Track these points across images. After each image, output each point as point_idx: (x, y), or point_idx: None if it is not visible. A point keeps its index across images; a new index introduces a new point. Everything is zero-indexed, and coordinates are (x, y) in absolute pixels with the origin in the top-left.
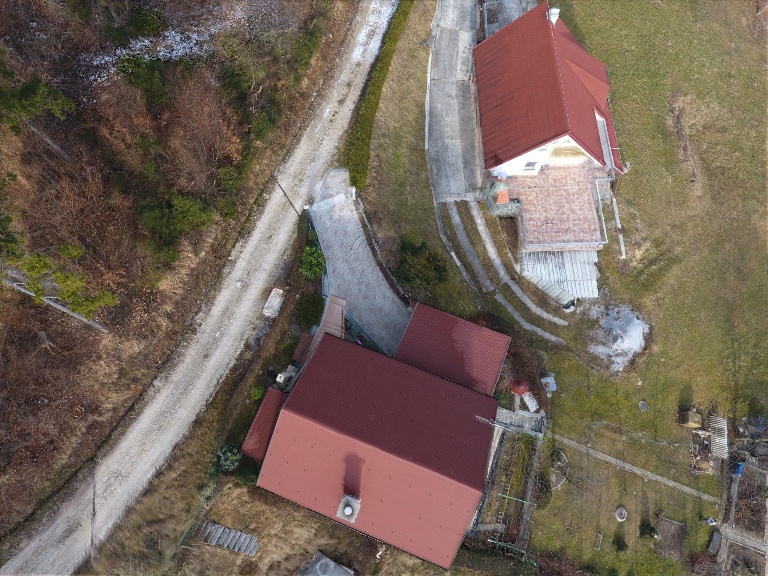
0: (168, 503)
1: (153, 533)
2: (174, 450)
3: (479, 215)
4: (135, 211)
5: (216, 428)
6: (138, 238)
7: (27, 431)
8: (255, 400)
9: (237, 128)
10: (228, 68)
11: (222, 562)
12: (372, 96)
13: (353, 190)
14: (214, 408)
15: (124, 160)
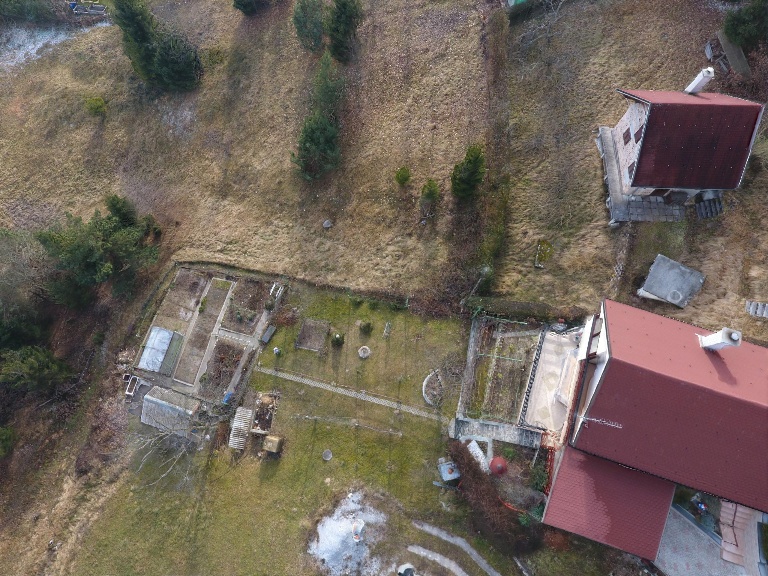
0: None
1: None
2: None
3: None
4: None
5: None
6: None
7: None
8: None
9: None
10: None
11: None
12: None
13: None
14: None
15: None
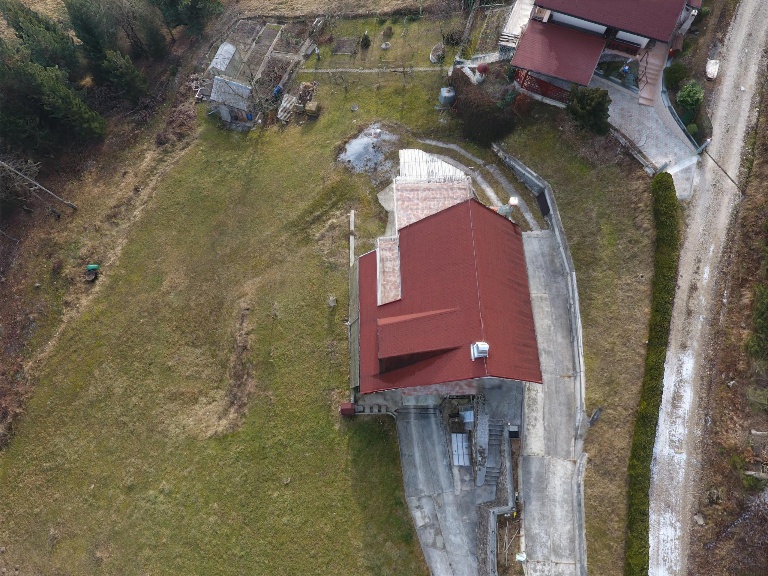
0: None
1: None
2: None
3: None
4: None
5: None
6: None
7: None
8: None
9: None
10: None
11: None
12: (668, 276)
13: None
14: None
15: None
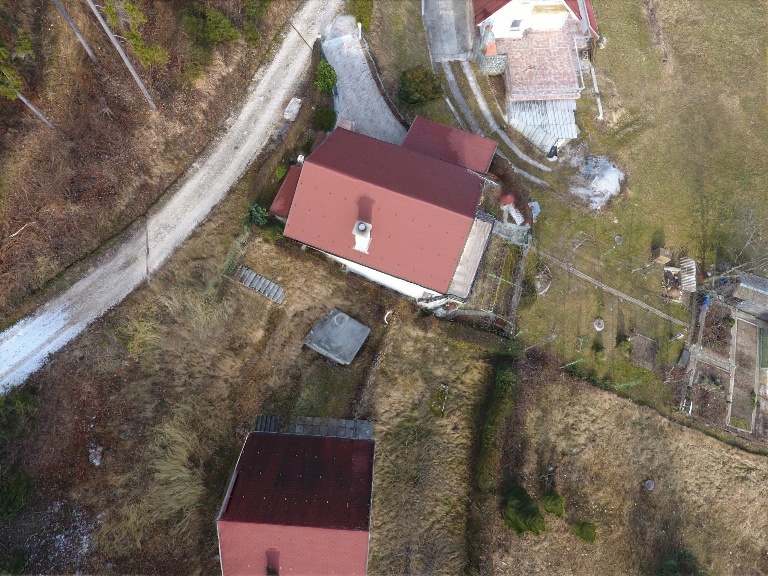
0: (210, 246)
1: (198, 268)
2: (213, 210)
3: (471, 73)
4: (175, 18)
5: (248, 191)
6: (179, 38)
7: (93, 176)
8: (279, 180)
9: None
10: None
11: (254, 304)
12: None
13: (359, 25)
14: (245, 181)
15: None
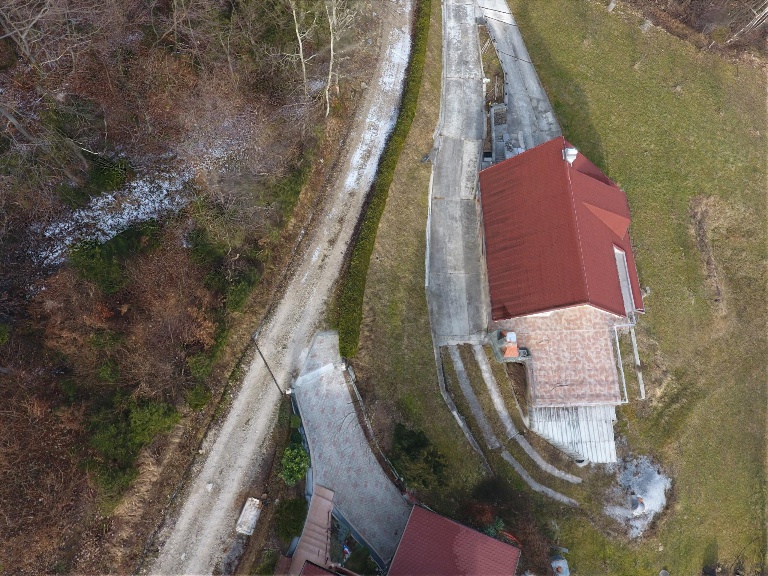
0: None
1: None
2: None
3: (484, 360)
4: (86, 429)
5: None
6: (88, 465)
7: None
8: None
9: (210, 303)
10: (201, 230)
11: None
12: (366, 242)
13: (342, 367)
14: None
15: (76, 359)
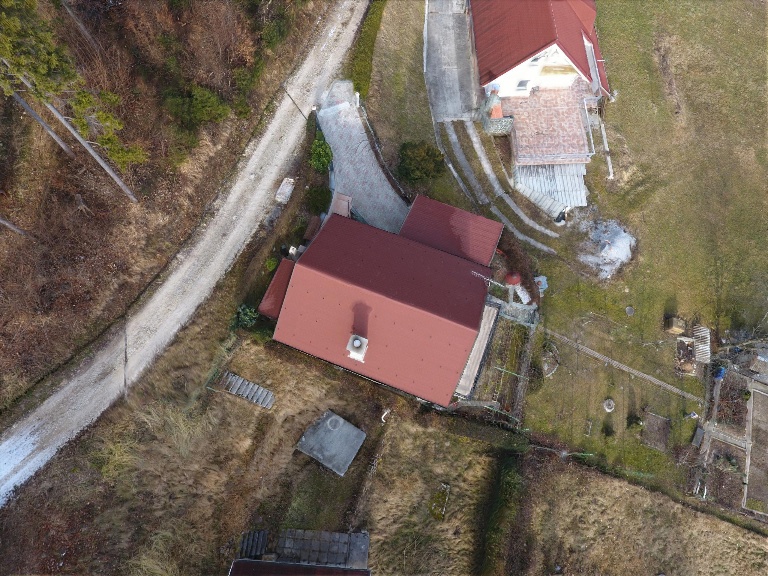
0: (193, 353)
1: (180, 378)
2: (197, 310)
3: (475, 134)
4: (159, 98)
5: None
6: (162, 121)
7: (66, 281)
8: (270, 272)
9: (250, 35)
10: None
11: (242, 412)
12: (374, 16)
13: (357, 95)
14: (233, 276)
15: (147, 56)
